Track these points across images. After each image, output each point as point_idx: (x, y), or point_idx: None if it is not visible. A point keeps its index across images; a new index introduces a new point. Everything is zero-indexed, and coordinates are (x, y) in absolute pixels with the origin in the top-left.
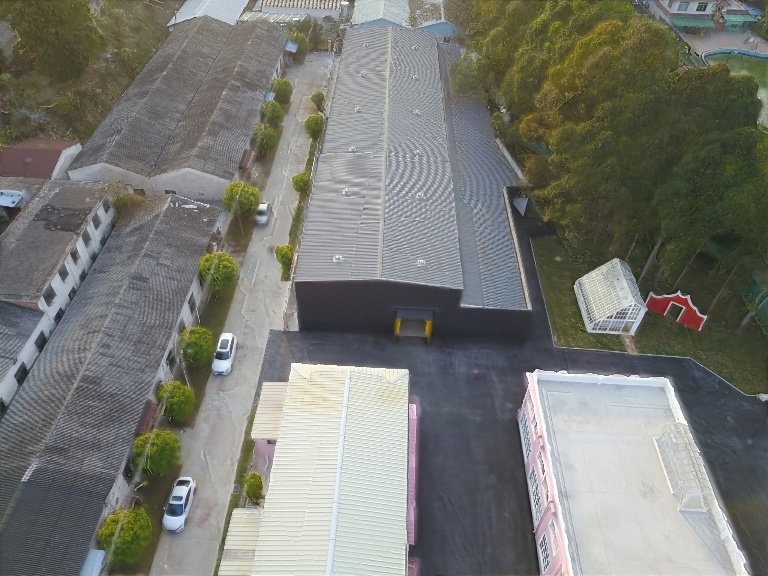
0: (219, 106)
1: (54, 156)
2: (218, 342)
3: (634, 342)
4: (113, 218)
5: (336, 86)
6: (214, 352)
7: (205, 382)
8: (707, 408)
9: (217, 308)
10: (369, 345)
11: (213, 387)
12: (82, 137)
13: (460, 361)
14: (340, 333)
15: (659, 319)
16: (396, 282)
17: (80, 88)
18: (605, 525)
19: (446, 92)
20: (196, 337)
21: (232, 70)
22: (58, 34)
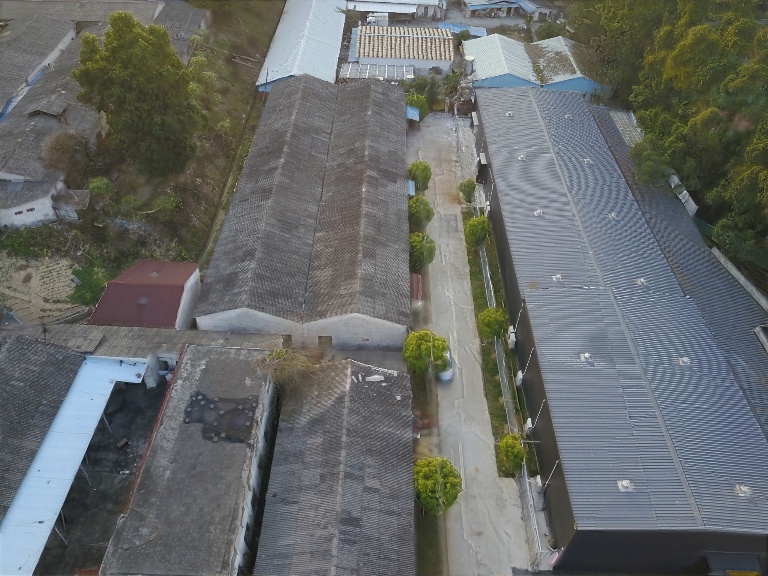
0: (364, 210)
1: (175, 295)
2: None
3: None
4: (278, 400)
5: (496, 176)
6: None
7: None
8: None
9: (430, 530)
10: None
11: None
12: (189, 248)
13: None
14: (610, 573)
15: None
16: (726, 532)
17: (179, 180)
18: None
19: None
20: None
21: (362, 154)
22: (164, 124)
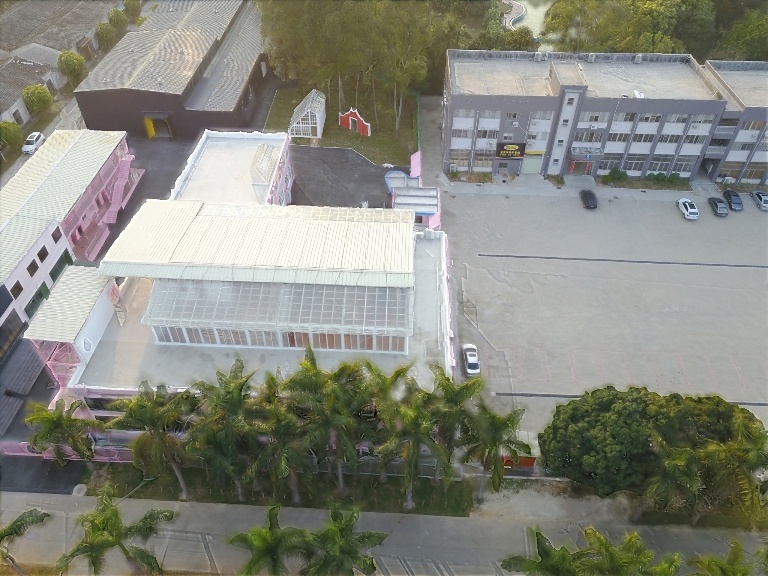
0: (72, 10)
1: None
2: (28, 136)
3: (319, 142)
4: None
5: None
6: (24, 141)
7: (17, 158)
8: (344, 171)
9: (40, 125)
10: (132, 141)
11: (21, 160)
12: None
13: (189, 148)
14: None
15: (345, 131)
16: (136, 90)
17: None
18: (203, 189)
19: (253, 2)
20: (6, 124)
21: None
22: None
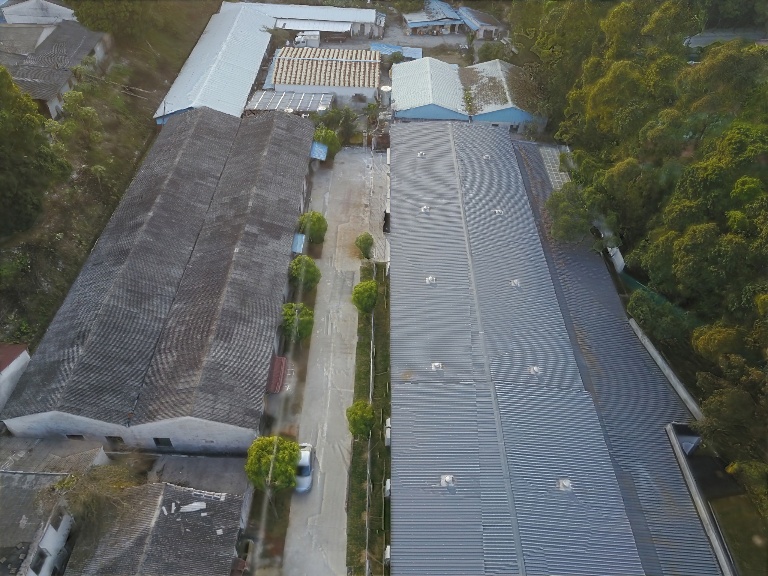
0: (230, 277)
1: None
2: None
3: None
4: (68, 539)
5: (392, 231)
6: None
7: None
8: None
9: None
10: None
11: None
12: (33, 320)
13: None
14: None
15: None
16: None
17: (32, 237)
18: None
19: (539, 229)
20: None
21: (245, 204)
22: None
